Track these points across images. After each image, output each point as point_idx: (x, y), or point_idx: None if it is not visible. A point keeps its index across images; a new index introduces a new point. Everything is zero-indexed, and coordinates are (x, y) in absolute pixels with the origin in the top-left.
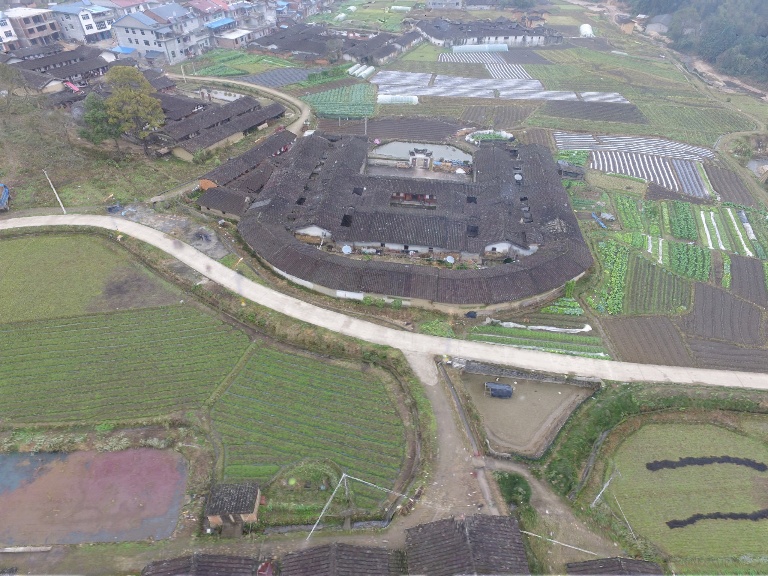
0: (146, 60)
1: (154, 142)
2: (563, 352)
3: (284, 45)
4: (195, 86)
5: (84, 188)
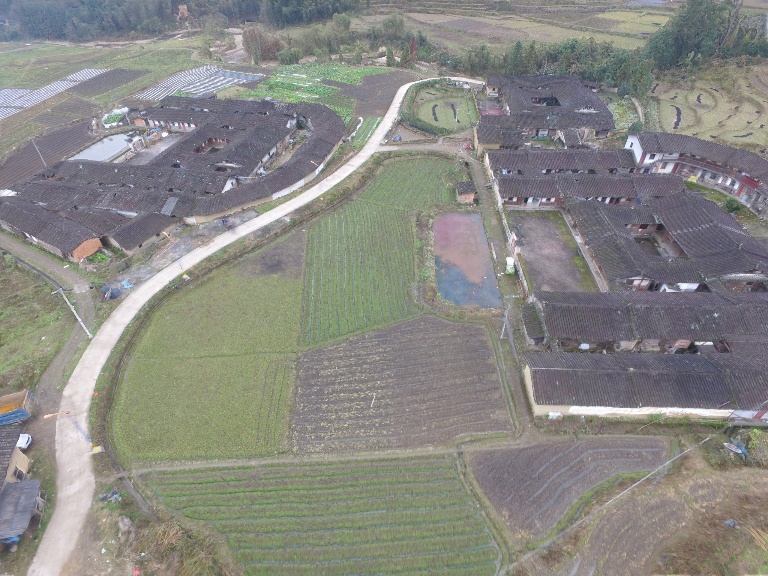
0: None
1: None
2: (376, 125)
3: None
4: None
5: None
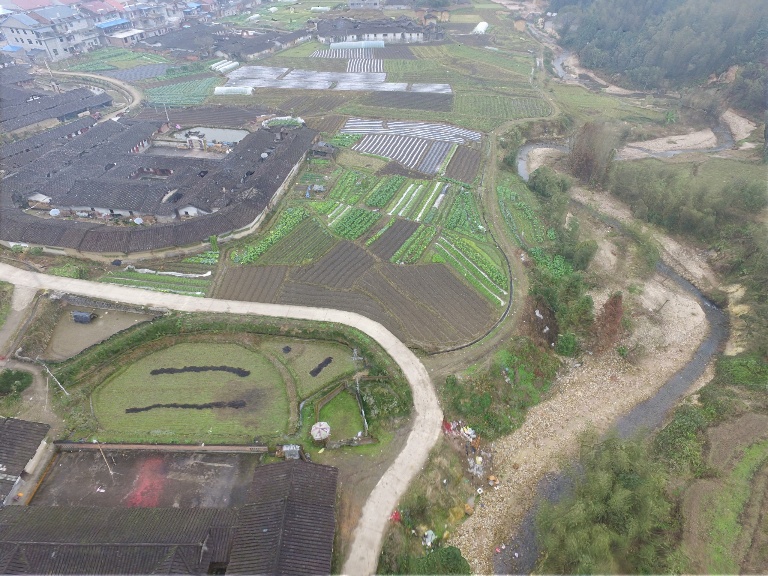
0: (28, 57)
1: None
2: (167, 291)
3: (168, 43)
4: (58, 80)
5: None
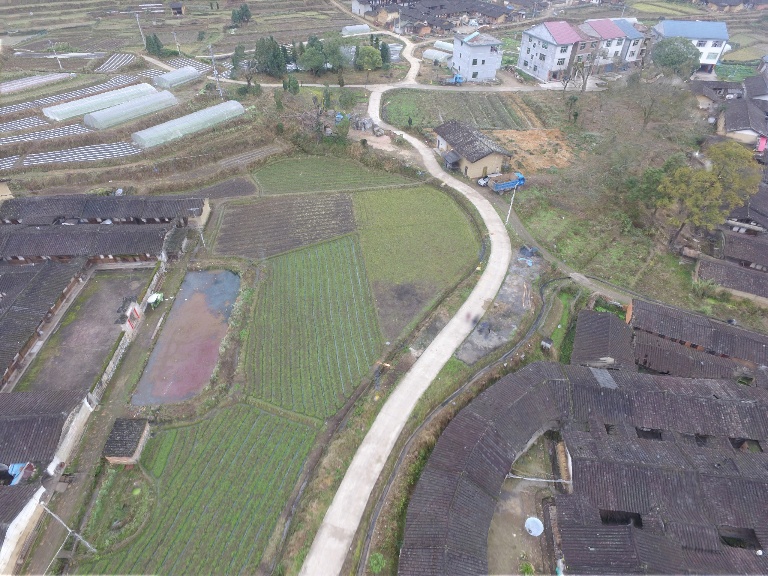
0: None
1: (715, 240)
2: None
3: None
4: None
5: (562, 221)
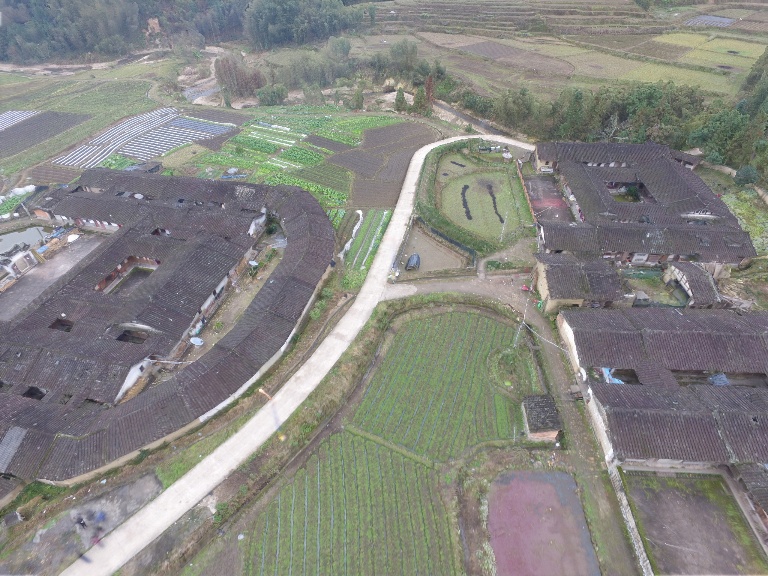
0: None
1: None
2: (381, 227)
3: None
4: None
5: None
